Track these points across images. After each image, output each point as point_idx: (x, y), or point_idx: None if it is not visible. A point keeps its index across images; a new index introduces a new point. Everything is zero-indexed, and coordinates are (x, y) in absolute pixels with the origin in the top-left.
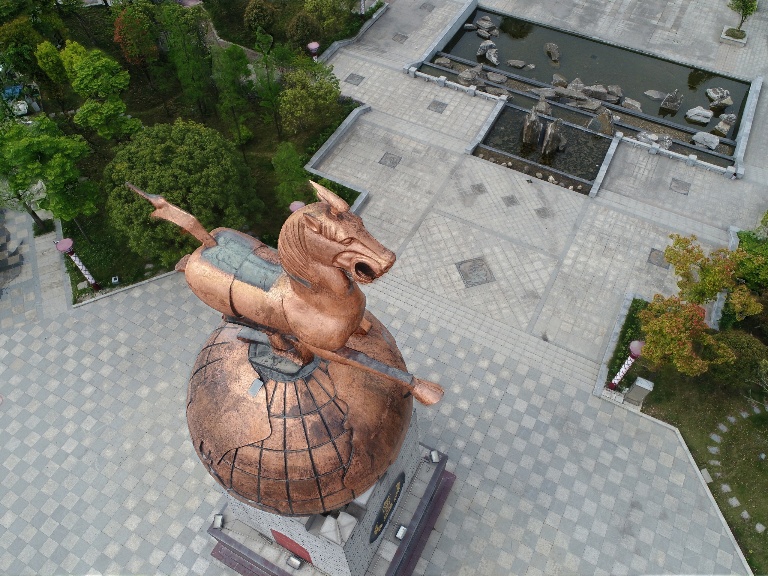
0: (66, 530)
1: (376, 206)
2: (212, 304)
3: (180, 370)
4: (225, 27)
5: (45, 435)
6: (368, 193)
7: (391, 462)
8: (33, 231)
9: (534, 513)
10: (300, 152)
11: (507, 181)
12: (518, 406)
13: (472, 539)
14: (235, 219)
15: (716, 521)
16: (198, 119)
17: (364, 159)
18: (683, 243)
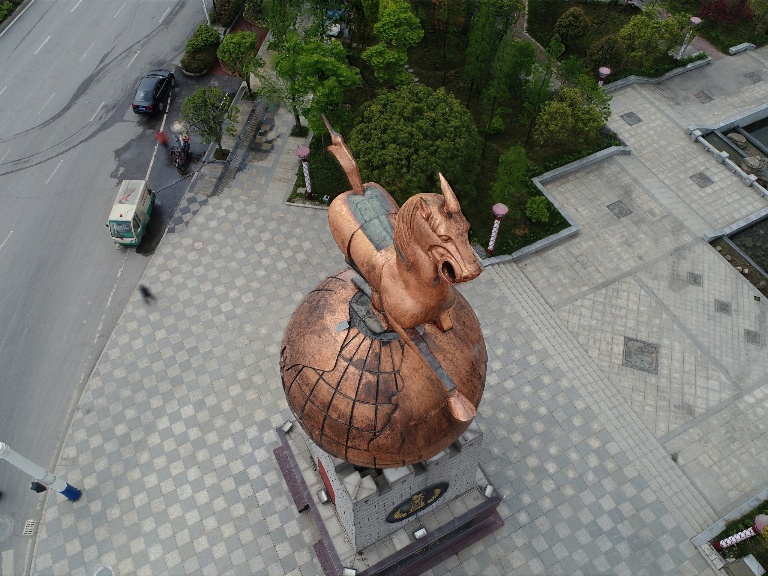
0: (191, 366)
1: (579, 245)
2: (336, 240)
3: None
4: (537, 24)
5: (215, 289)
6: (579, 229)
7: (422, 457)
8: (291, 131)
9: None
10: (537, 163)
11: (732, 286)
12: (604, 502)
13: None
14: None
15: None
16: (466, 96)
17: (594, 197)
18: None
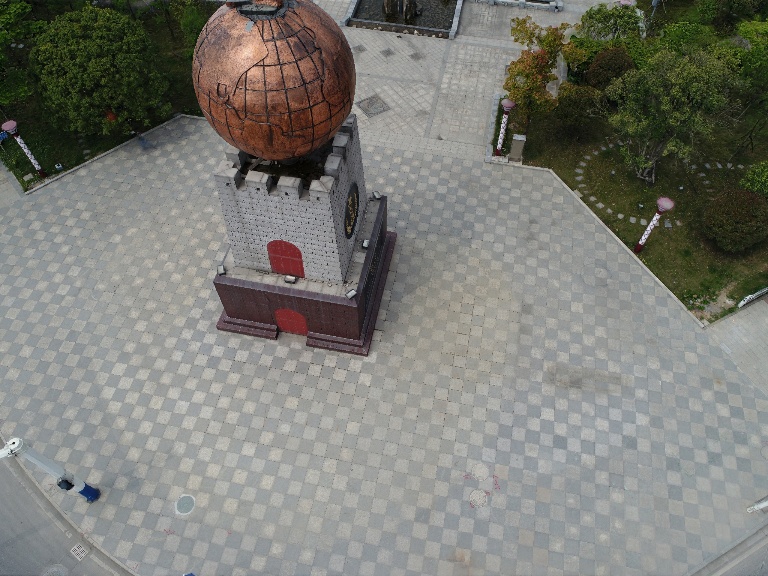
0: (83, 345)
1: None
2: None
3: (144, 217)
4: None
5: (37, 288)
6: None
7: (350, 96)
8: None
9: (461, 243)
10: None
11: (381, 40)
12: (431, 181)
13: (420, 270)
14: (160, 83)
15: (590, 218)
16: None
17: None
18: (522, 23)
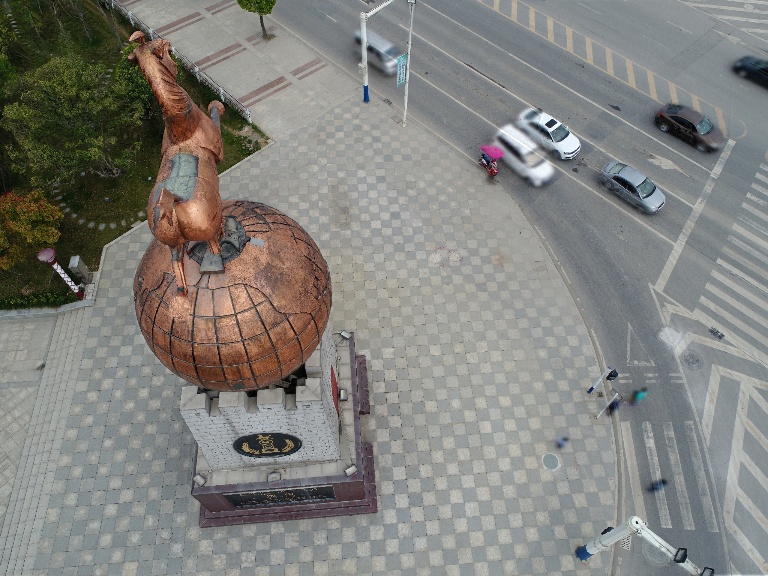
0: None
1: None
2: None
3: None
4: None
5: None
6: None
7: None
8: None
9: None
10: None
11: None
12: (128, 352)
13: None
14: None
15: None
16: None
17: None
18: None
